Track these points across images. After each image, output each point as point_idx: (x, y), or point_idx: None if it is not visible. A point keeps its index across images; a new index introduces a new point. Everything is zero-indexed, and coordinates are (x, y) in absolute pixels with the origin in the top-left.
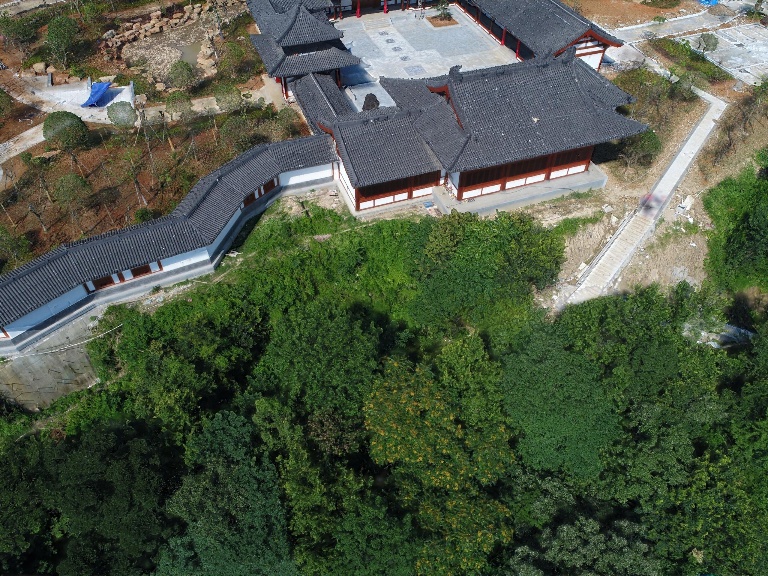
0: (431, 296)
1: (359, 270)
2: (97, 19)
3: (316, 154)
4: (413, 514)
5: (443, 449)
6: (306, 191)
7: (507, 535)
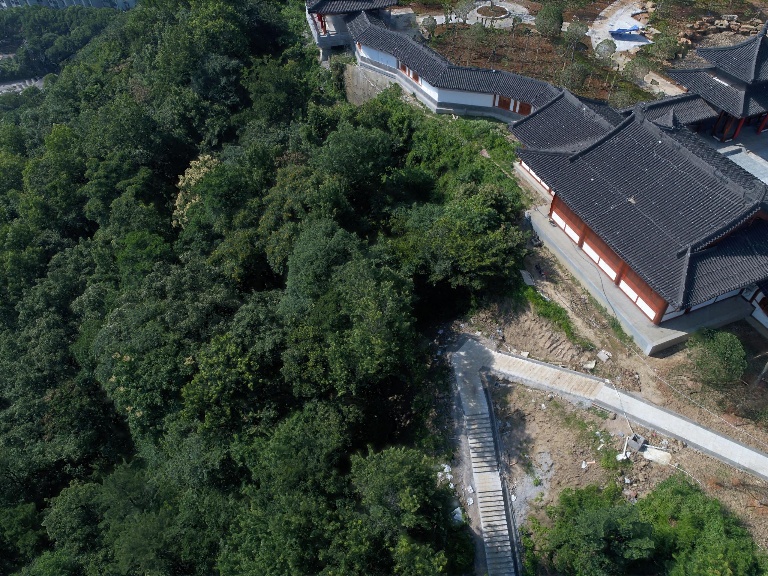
0: None
1: None
2: (733, 0)
3: None
4: None
5: None
6: None
7: (235, 275)
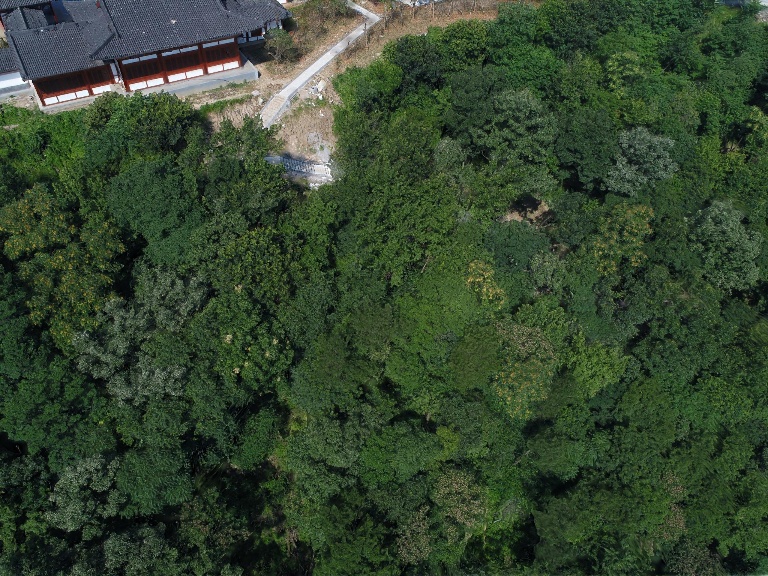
0: (86, 156)
1: (47, 152)
2: None
3: (4, 63)
4: (29, 283)
5: (53, 238)
6: (6, 97)
7: None
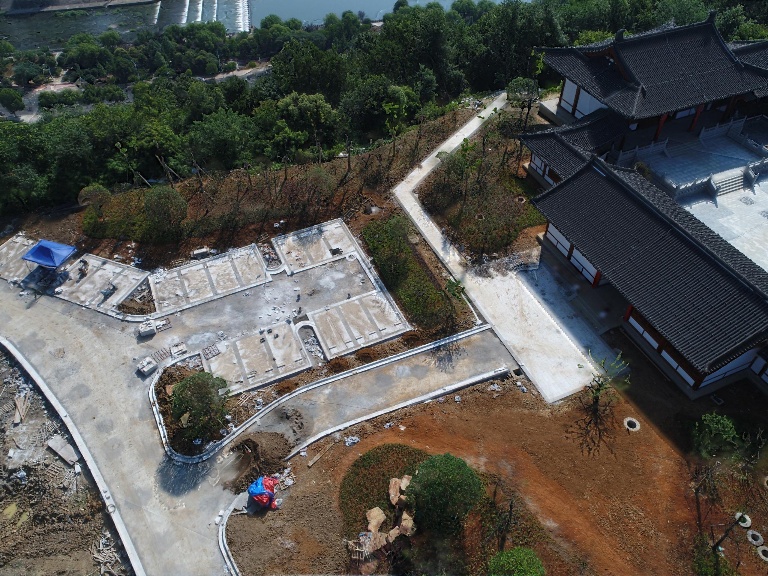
0: None
1: None
2: None
3: None
4: None
5: None
6: None
7: None
